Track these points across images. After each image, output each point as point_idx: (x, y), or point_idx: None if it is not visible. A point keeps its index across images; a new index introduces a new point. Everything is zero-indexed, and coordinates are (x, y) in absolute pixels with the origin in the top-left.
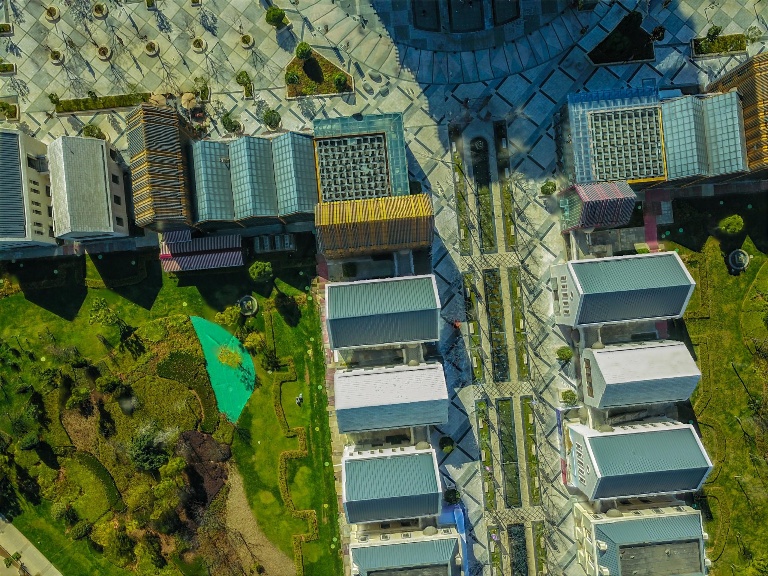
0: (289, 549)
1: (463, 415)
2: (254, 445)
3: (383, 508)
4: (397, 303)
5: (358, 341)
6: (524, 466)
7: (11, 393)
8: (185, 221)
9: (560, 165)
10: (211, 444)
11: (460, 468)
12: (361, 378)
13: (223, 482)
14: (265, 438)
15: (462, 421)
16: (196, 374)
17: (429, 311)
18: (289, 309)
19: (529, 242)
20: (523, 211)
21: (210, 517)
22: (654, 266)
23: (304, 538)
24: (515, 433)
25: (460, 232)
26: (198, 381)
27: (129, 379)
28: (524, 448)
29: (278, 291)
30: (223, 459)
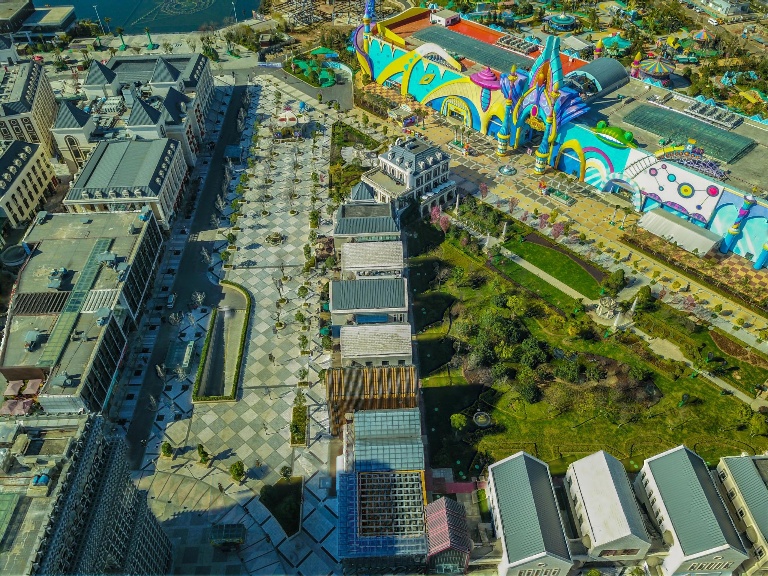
0: None
1: None
2: None
3: None
4: None
5: None
6: None
7: None
8: None
9: (396, 572)
10: None
11: None
12: None
13: None
14: None
15: None
16: None
17: None
18: None
19: None
20: None
21: None
22: (506, 485)
23: None
24: None
25: None
26: None
27: None
28: None
29: None
30: None
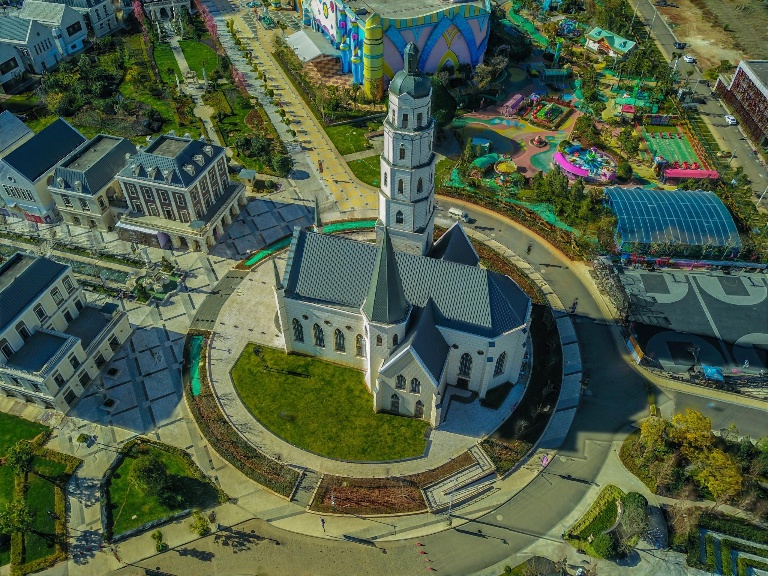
0: None
1: None
2: None
3: None
4: None
5: None
6: (8, 241)
7: None
8: None
9: None
10: None
11: None
12: None
13: None
14: None
15: None
16: None
17: None
18: None
19: None
20: None
21: None
22: None
23: None
24: None
25: None
26: None
27: None
28: None
29: None
30: None
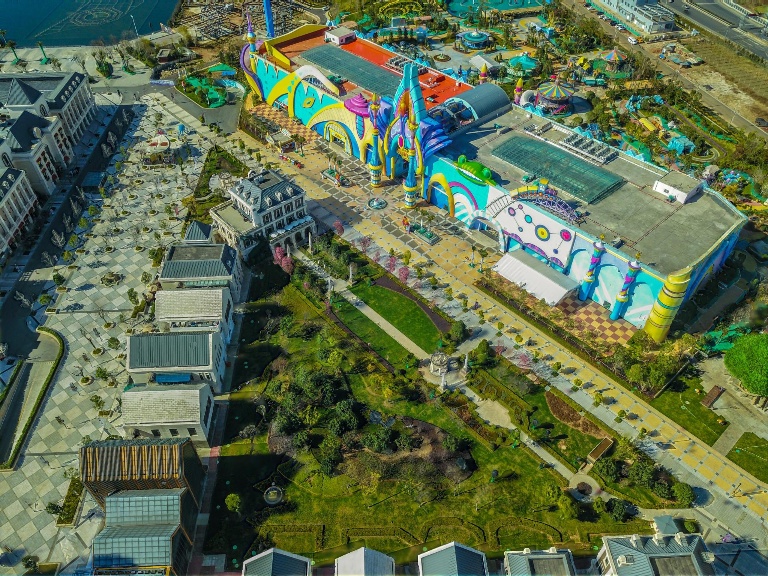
0: None
1: None
2: None
3: None
4: None
5: None
6: None
7: None
8: None
9: None
10: None
11: None
12: None
13: None
14: None
15: None
16: None
17: None
18: None
19: None
20: None
21: None
22: None
23: None
24: None
25: None
26: None
27: None
28: None
29: None
30: None
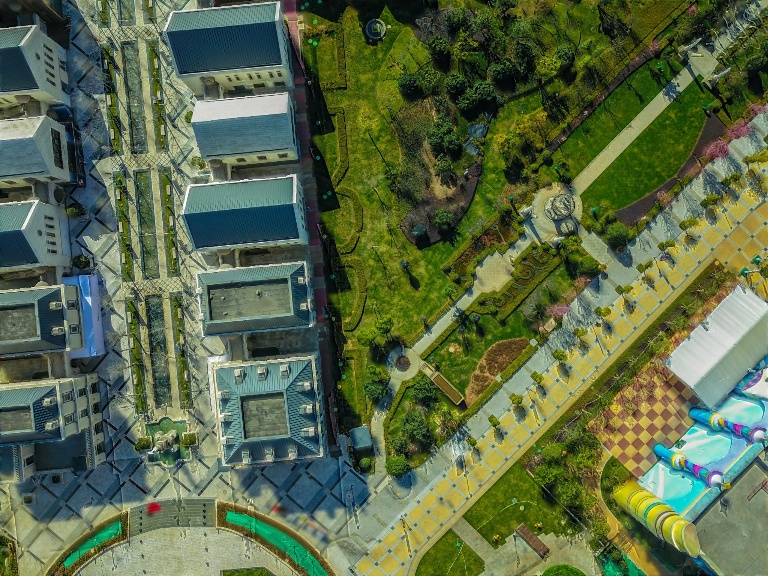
0: None
1: (101, 187)
2: None
3: None
4: None
5: None
6: (162, 237)
7: None
8: None
9: None
10: None
11: (98, 240)
12: None
13: None
14: None
15: (100, 193)
16: None
17: (13, 50)
18: None
19: (167, 14)
20: None
21: None
22: (251, 11)
23: None
24: (153, 205)
25: (97, 4)
26: None
27: None
28: (162, 219)
29: None
30: None
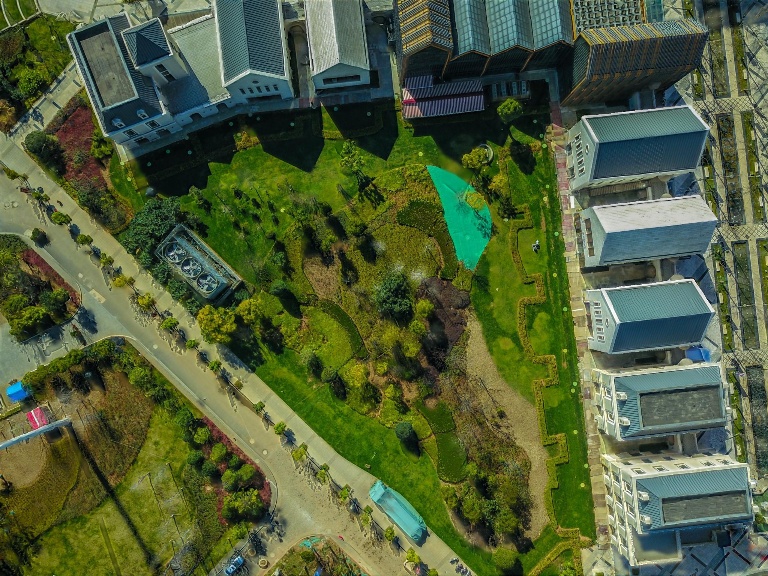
0: (530, 394)
1: (699, 259)
2: (492, 292)
3: (650, 333)
4: (663, 128)
5: (618, 171)
6: (761, 308)
7: (253, 243)
8: (450, 51)
9: None
10: (451, 291)
11: None
12: (621, 208)
13: (463, 329)
14: (503, 285)
15: (699, 265)
16: (435, 222)
17: (697, 134)
18: (524, 157)
19: (762, 86)
20: (755, 55)
21: (451, 363)
22: None
23: (545, 383)
24: (752, 276)
25: (693, 77)
26: (437, 228)
27: (369, 228)
28: (761, 290)
29: (513, 139)
30: (463, 305)
